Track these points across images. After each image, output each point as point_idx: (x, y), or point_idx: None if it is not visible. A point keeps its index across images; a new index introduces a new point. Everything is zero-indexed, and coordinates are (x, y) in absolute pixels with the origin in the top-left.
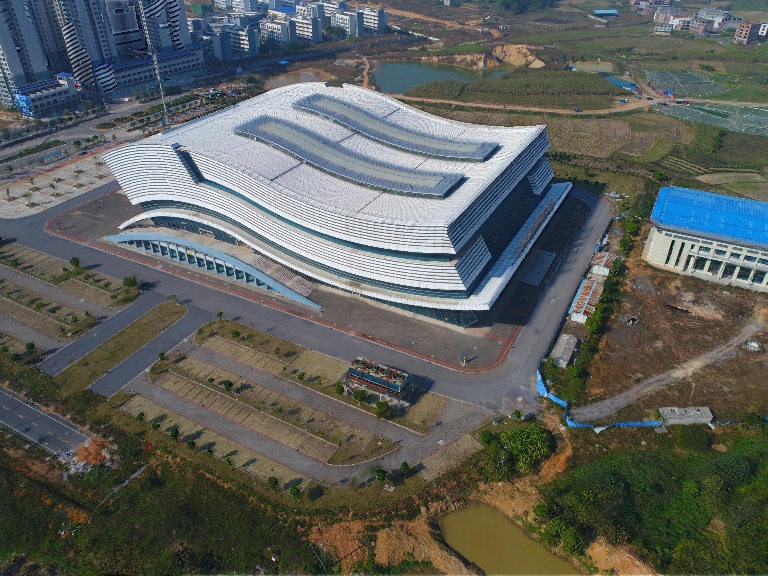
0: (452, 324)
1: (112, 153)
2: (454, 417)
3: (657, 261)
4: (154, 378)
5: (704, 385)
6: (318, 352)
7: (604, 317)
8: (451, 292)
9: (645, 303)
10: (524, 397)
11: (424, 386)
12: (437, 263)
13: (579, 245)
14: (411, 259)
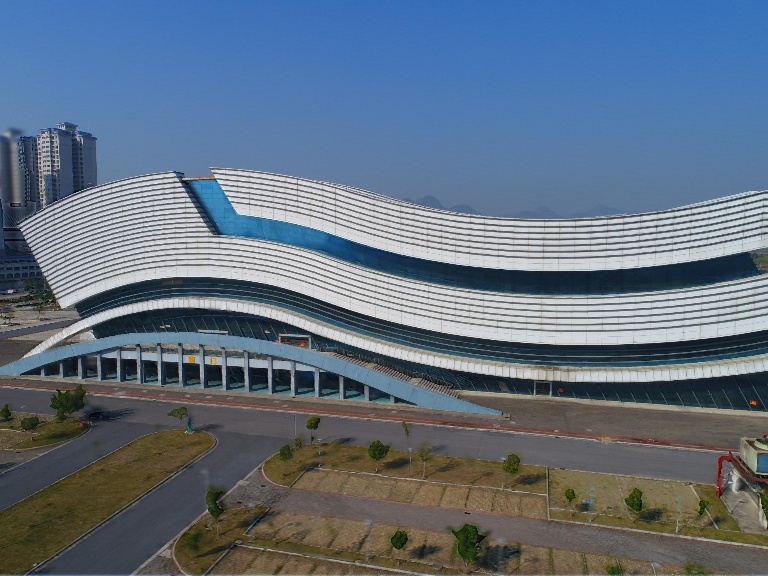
0: (767, 411)
1: (42, 214)
2: None
3: None
4: (199, 567)
5: None
6: (584, 471)
7: None
8: (764, 339)
9: None
10: None
11: None
12: (737, 280)
13: None
14: (672, 289)
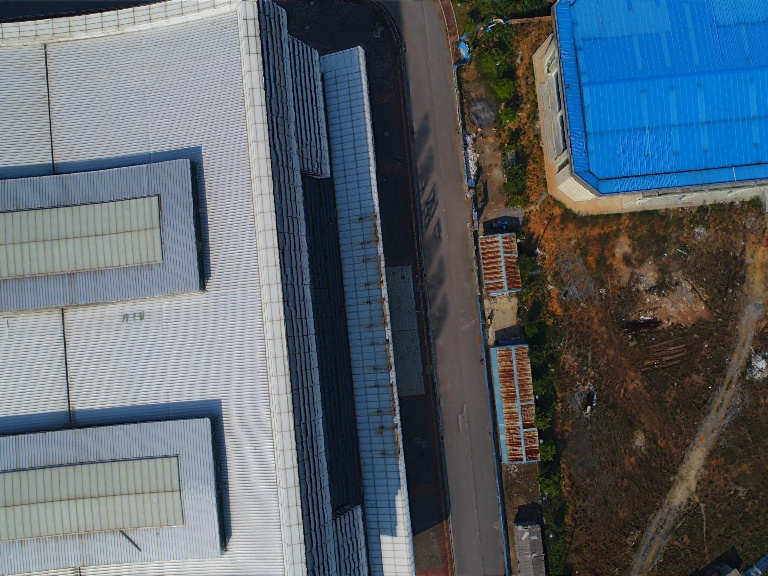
0: None
1: None
2: None
3: (579, 199)
4: None
5: (716, 502)
6: None
7: (549, 422)
8: None
9: (592, 337)
10: None
11: None
12: None
13: (434, 206)
14: None
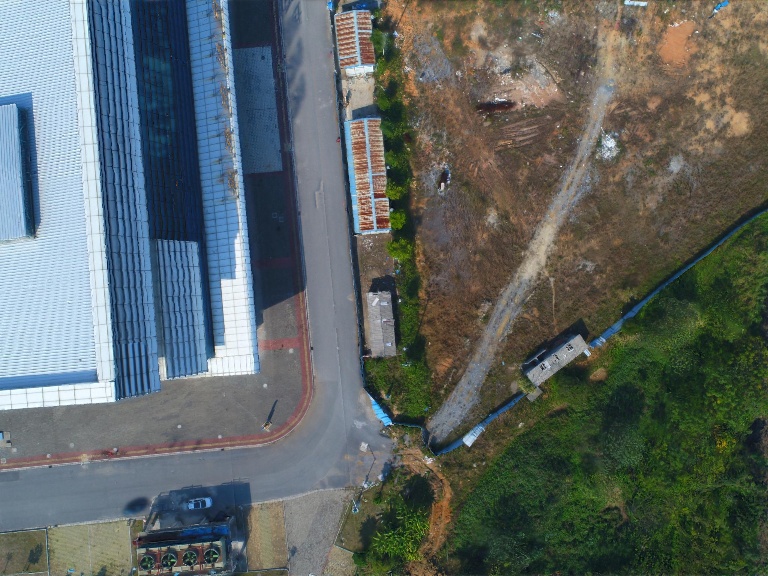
0: None
1: None
2: (305, 530)
3: None
4: None
5: (564, 275)
6: (69, 525)
7: (404, 198)
8: None
9: (448, 118)
10: (367, 441)
11: (241, 499)
12: None
13: None
14: None
